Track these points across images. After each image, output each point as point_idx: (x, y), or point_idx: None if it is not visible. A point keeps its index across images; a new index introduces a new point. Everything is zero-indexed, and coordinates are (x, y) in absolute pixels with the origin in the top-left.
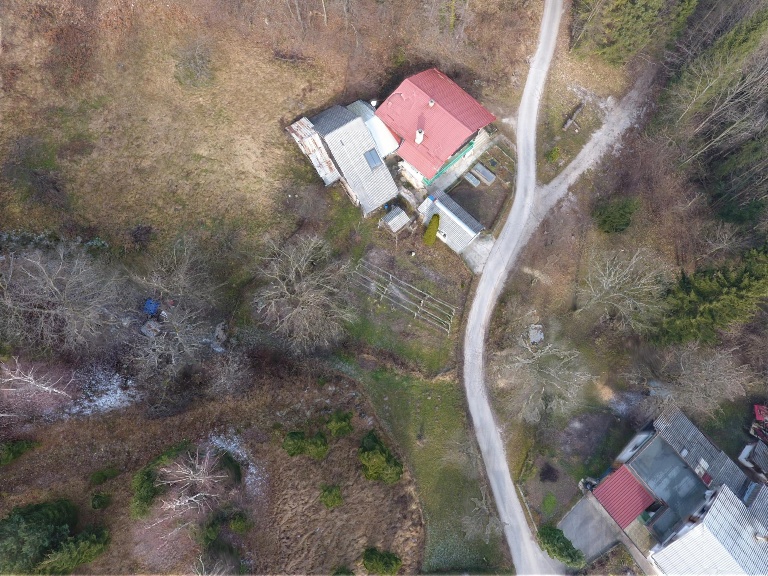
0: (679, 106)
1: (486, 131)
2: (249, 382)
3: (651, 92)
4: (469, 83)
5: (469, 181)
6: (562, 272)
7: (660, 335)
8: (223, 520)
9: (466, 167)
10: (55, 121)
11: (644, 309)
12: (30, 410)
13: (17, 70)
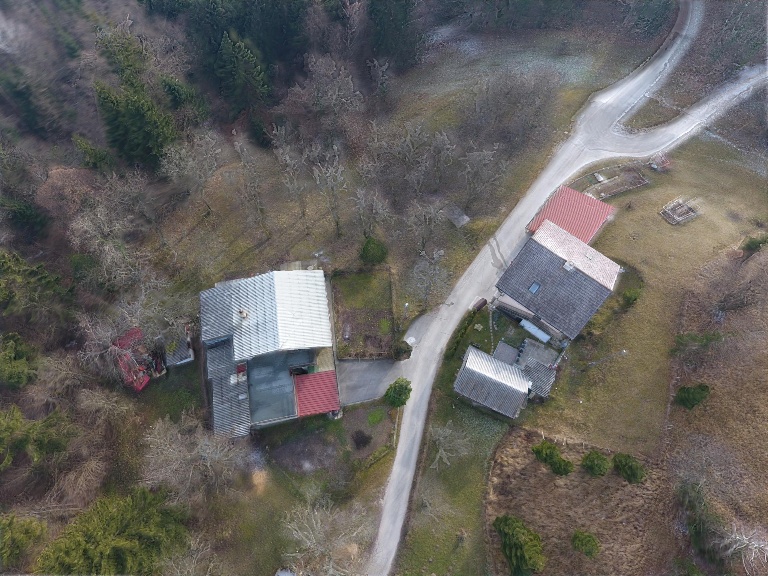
0: None
1: None
2: None
3: None
4: None
5: None
6: None
7: (178, 515)
8: None
9: None
10: None
11: None
12: None
13: None
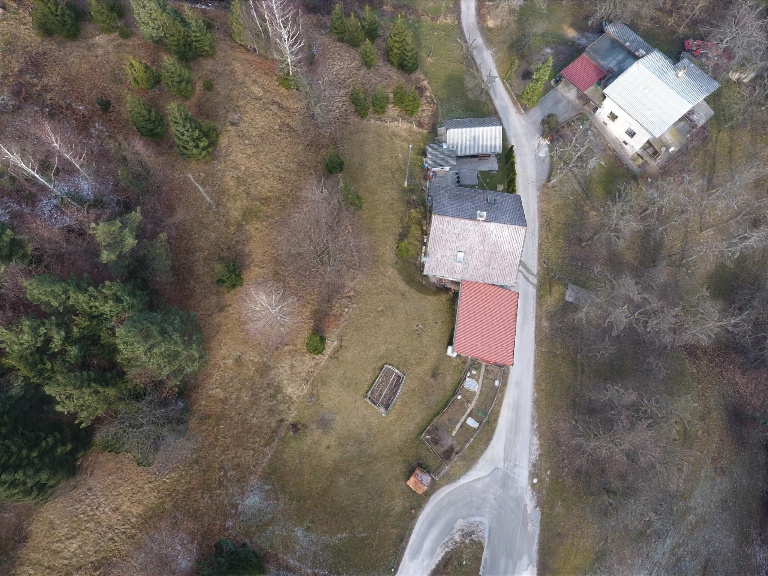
0: None
1: None
2: None
3: None
4: None
5: None
6: None
7: None
8: None
9: None
10: None
11: None
12: None
13: None
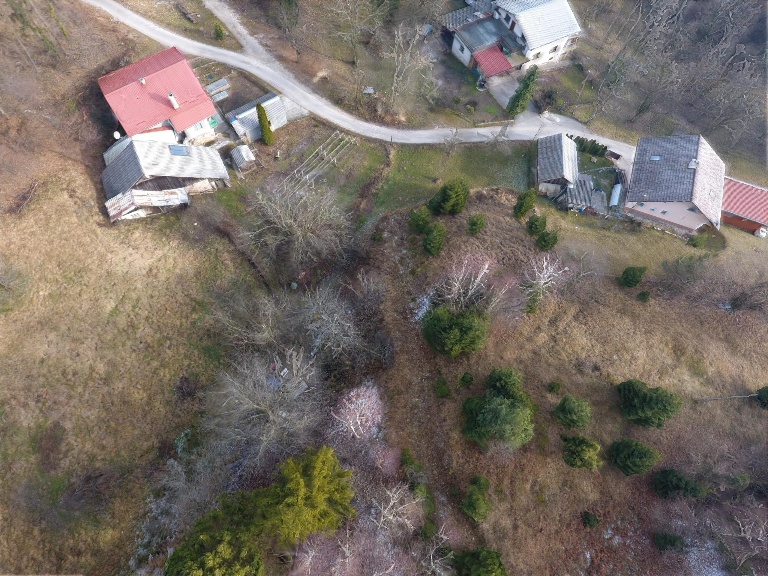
0: None
1: None
2: None
3: None
4: None
5: (221, 99)
6: (321, 61)
7: (390, 3)
8: (490, 285)
9: None
10: None
11: None
12: (369, 470)
13: None
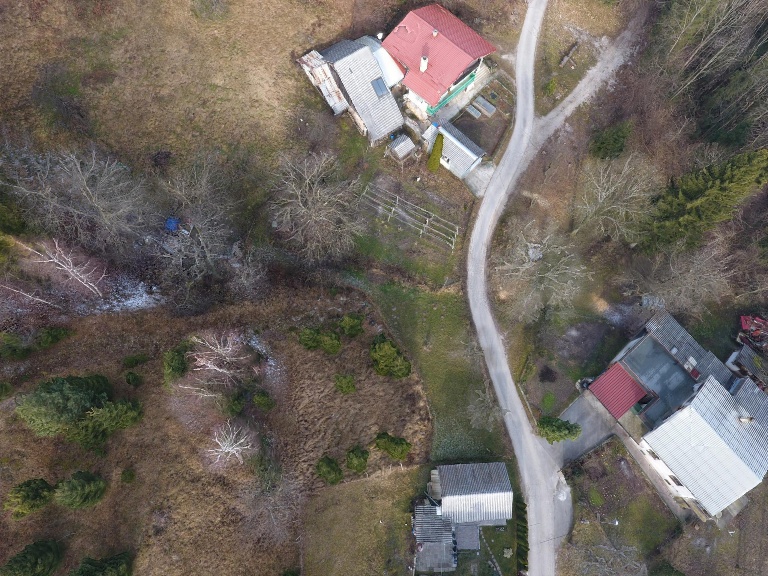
0: (669, 37)
1: (487, 66)
2: (265, 292)
3: (644, 32)
4: (470, 21)
5: (471, 113)
6: (559, 196)
7: (651, 244)
8: (247, 397)
9: (468, 100)
10: (78, 51)
11: (636, 220)
12: (64, 305)
13: (42, 1)
